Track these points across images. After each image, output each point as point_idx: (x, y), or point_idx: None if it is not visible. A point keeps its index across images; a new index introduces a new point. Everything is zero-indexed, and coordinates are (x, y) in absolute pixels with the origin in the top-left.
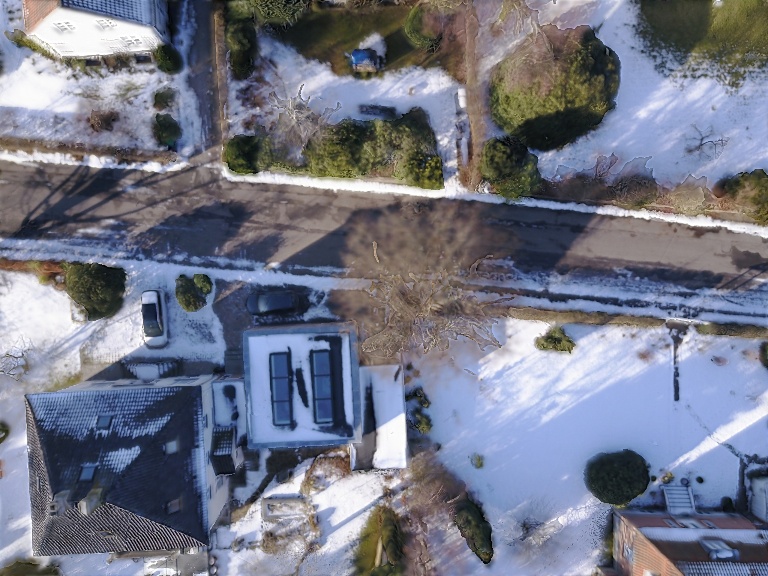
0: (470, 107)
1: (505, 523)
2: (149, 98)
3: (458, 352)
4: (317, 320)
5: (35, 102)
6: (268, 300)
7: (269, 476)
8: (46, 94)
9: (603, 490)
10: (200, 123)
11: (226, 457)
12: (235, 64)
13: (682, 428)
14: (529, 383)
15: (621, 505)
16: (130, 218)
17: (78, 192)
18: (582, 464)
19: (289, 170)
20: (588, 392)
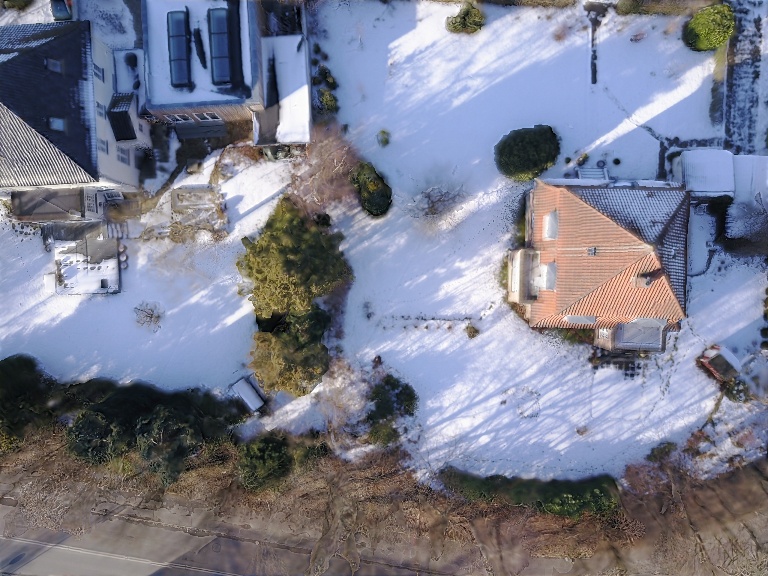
0: None
1: None
2: None
3: (367, 36)
4: None
5: None
6: None
7: (179, 167)
8: None
9: (509, 156)
10: None
11: (123, 114)
12: None
13: (599, 111)
14: (440, 67)
15: (529, 174)
16: None
17: None
18: None
19: None
20: (501, 75)
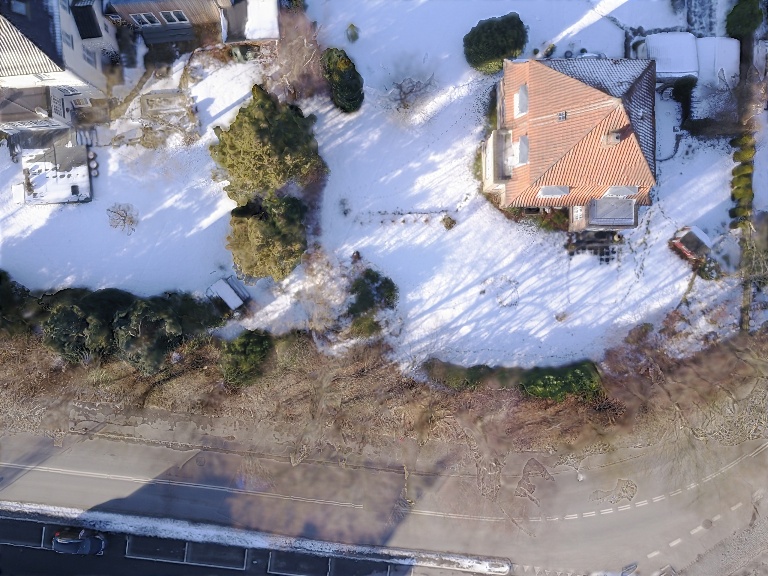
0: None
1: None
2: None
3: None
4: None
5: None
6: None
7: (147, 73)
8: None
9: (478, 44)
10: None
11: (88, 9)
12: None
13: (565, 2)
14: None
15: (498, 62)
16: None
17: None
18: None
19: None
20: None
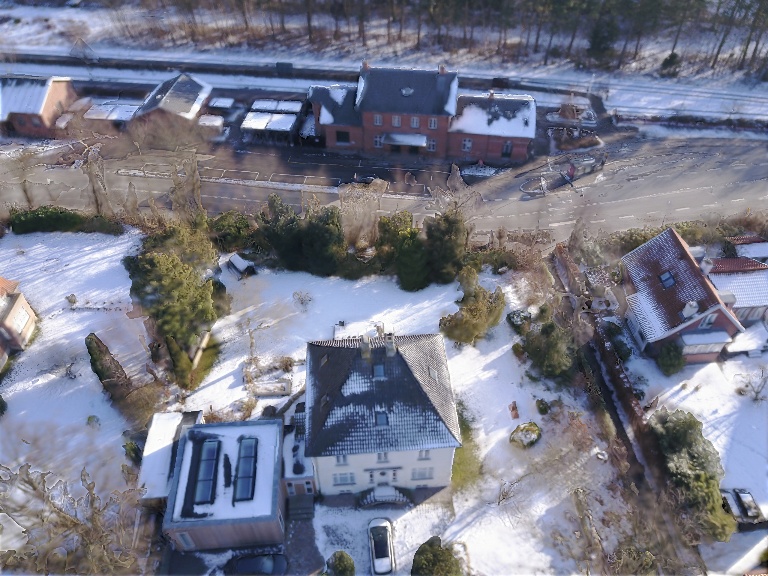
0: None
1: (88, 379)
2: None
3: None
4: (219, 551)
5: None
6: (262, 567)
7: (283, 412)
8: None
9: None
10: None
11: (299, 411)
12: None
13: None
14: None
15: None
16: None
17: None
18: (3, 423)
19: None
20: None
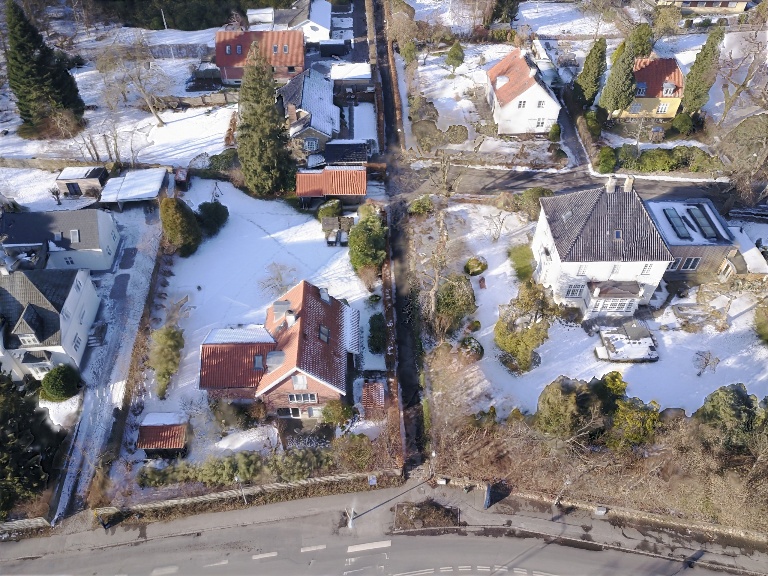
0: (723, 143)
1: None
2: (545, 149)
3: None
4: None
5: (484, 150)
6: None
7: (671, 295)
8: (491, 146)
9: None
10: (574, 157)
11: None
12: (594, 131)
13: None
14: None
15: None
16: None
17: (511, 179)
18: None
19: (632, 167)
20: None
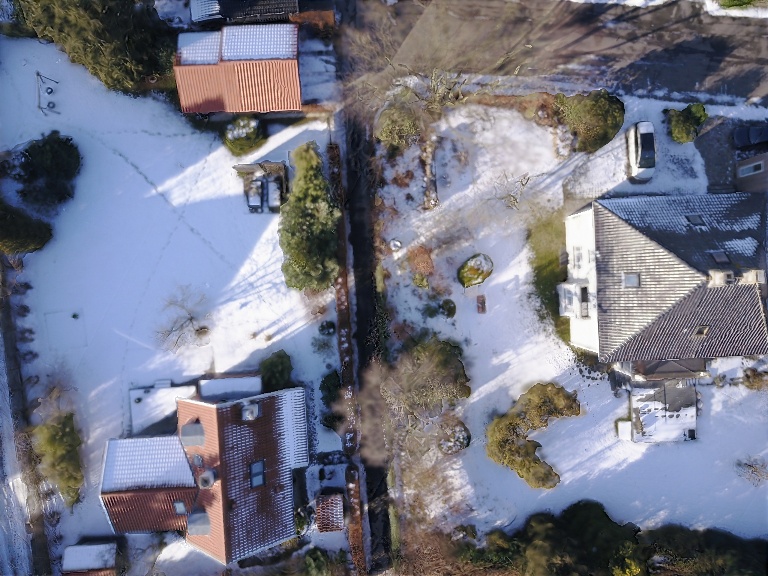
0: None
1: None
2: None
3: None
4: None
5: None
6: (761, 131)
7: None
8: None
9: None
10: None
11: None
12: None
13: None
14: None
15: None
16: (611, 53)
17: (559, 27)
18: None
19: None
20: None
